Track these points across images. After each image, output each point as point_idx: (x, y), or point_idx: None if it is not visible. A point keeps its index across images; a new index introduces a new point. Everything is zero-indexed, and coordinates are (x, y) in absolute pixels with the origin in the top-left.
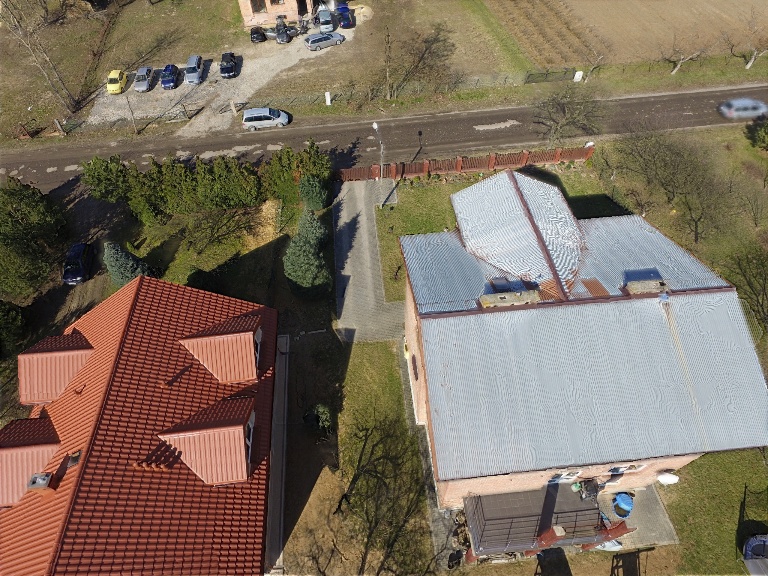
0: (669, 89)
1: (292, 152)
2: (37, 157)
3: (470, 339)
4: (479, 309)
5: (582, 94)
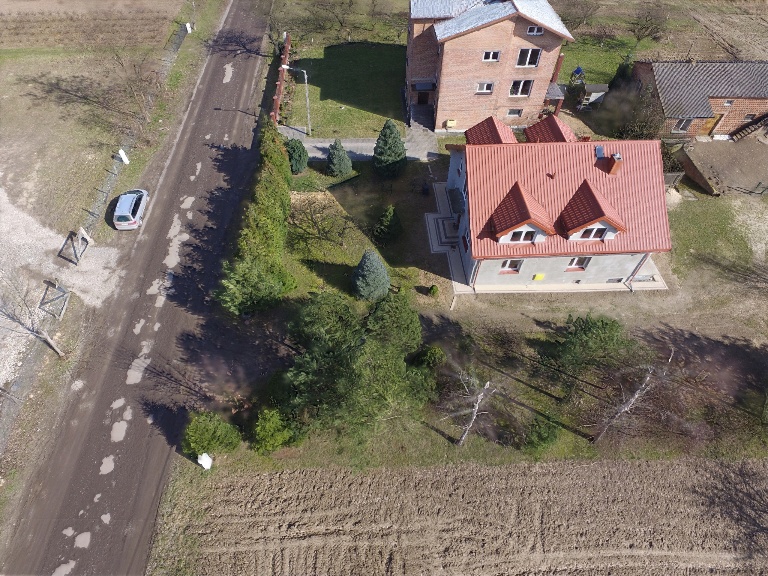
0: (224, 6)
1: None
2: (47, 514)
3: (524, 8)
4: (512, 0)
5: (208, 34)
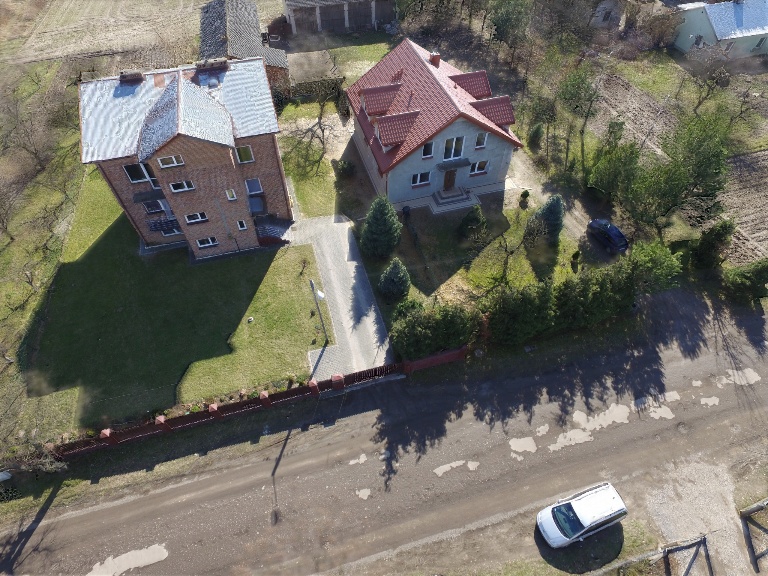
0: None
1: (439, 309)
2: None
3: None
4: (229, 63)
5: None
